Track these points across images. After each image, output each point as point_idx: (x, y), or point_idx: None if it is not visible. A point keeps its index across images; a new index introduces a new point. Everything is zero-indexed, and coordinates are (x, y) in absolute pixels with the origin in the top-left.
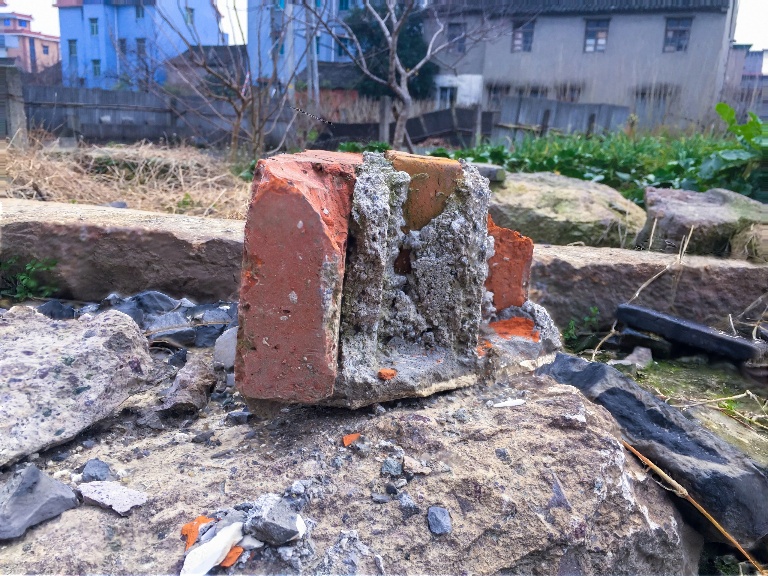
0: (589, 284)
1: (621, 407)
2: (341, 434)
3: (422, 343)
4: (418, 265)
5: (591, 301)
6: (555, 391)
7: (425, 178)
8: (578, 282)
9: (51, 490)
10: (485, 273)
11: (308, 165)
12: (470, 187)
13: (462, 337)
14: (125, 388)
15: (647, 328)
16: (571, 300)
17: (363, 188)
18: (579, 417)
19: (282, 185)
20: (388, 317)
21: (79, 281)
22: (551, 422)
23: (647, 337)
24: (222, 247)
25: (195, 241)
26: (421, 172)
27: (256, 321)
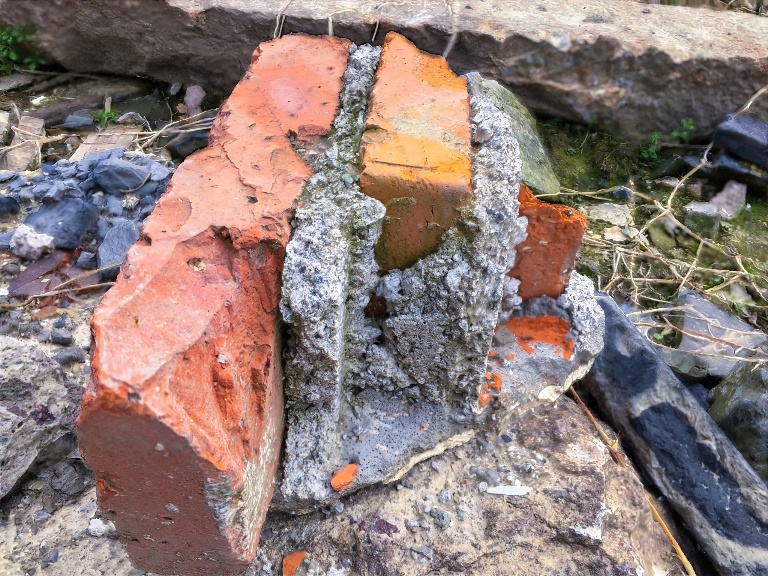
0: (689, 83)
1: (665, 436)
2: (283, 547)
3: (403, 397)
4: (396, 324)
5: (687, 105)
6: (574, 460)
7: (410, 204)
8: (675, 81)
9: None
10: (510, 263)
11: (205, 237)
12: (481, 220)
13: (458, 390)
14: (31, 445)
15: (749, 158)
16: (661, 102)
17: (298, 264)
18: (593, 531)
19: (117, 402)
20: (358, 368)
21: (67, 52)
22: (554, 537)
23: (746, 171)
24: (225, 18)
25: (192, 8)
26: (404, 196)
27: (128, 523)
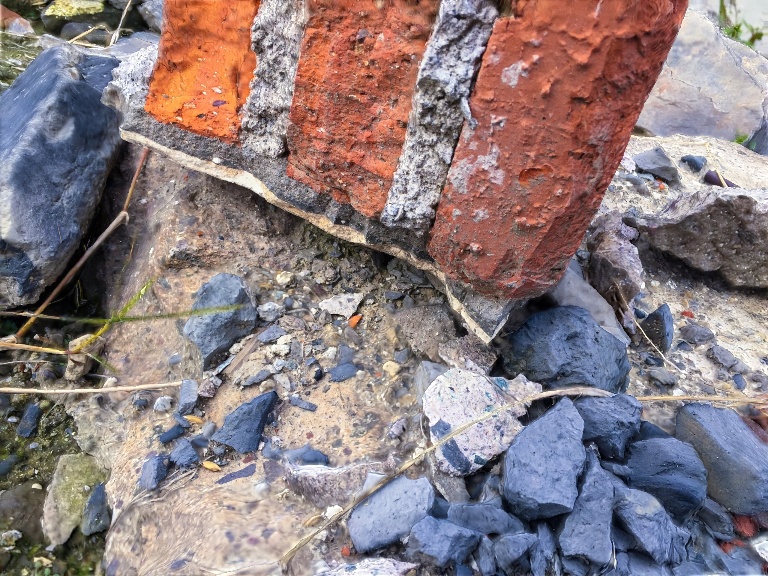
0: None
1: None
2: None
3: None
4: None
5: None
6: None
7: None
8: None
9: (646, 154)
10: None
11: None
12: None
13: None
14: None
15: None
16: None
17: None
18: None
19: None
20: None
21: None
22: None
23: None
24: None
25: None
26: None
27: None
